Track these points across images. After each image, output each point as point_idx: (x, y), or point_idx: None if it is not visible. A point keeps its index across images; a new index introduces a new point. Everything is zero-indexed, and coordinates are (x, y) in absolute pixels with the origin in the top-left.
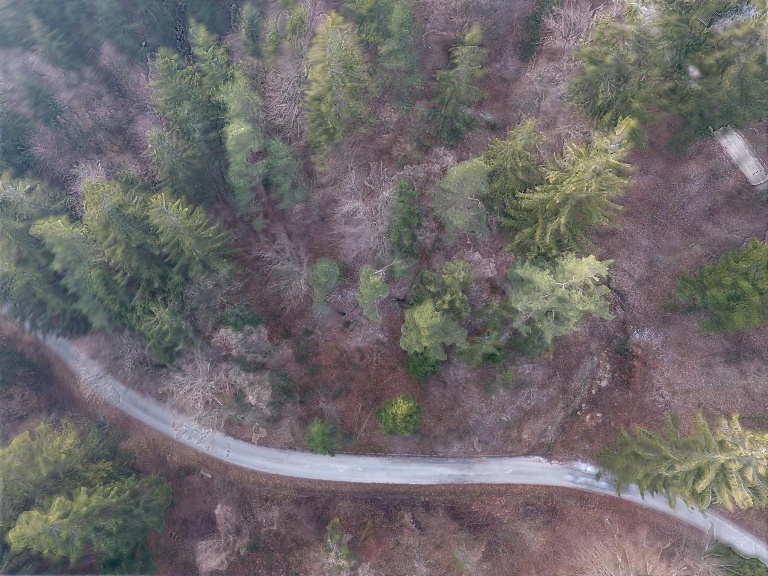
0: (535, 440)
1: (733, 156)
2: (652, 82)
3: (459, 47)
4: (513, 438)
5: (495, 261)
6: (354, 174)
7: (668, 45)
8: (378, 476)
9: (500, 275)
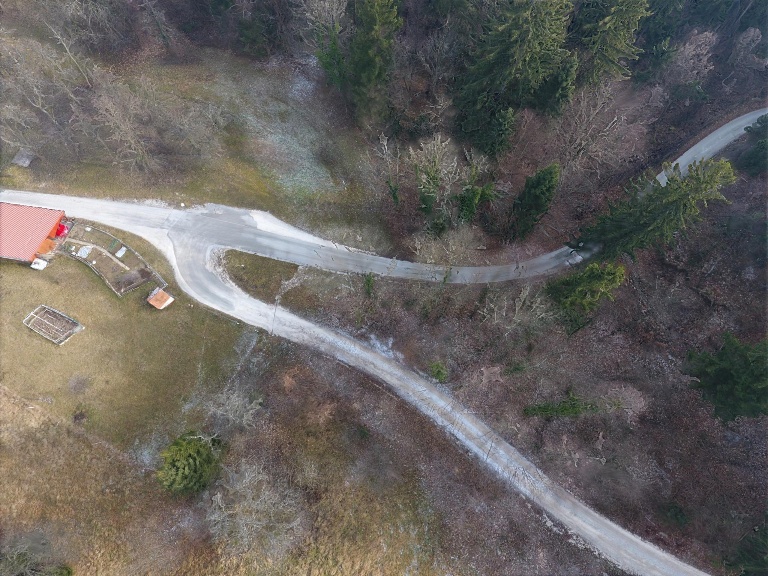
0: None
1: None
2: None
3: None
4: None
5: None
6: None
7: None
8: (684, 160)
9: None
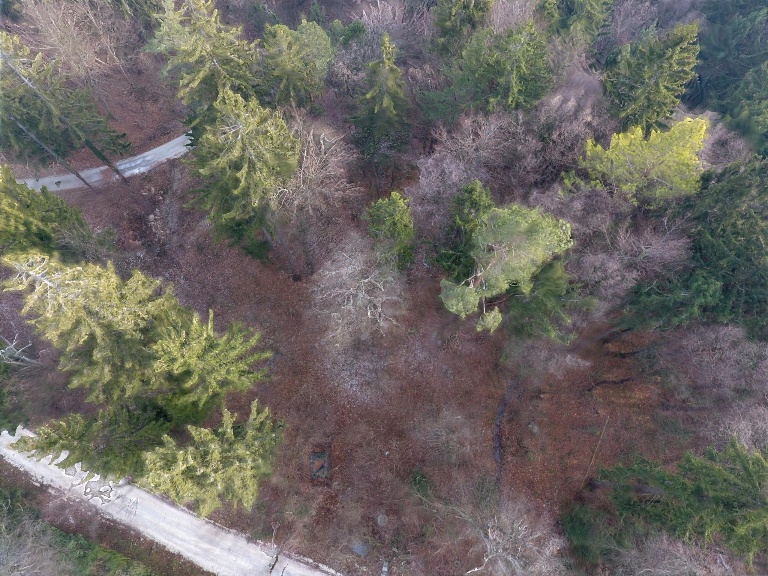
0: None
1: None
2: None
3: None
4: None
5: None
6: (400, 17)
7: None
8: None
9: None
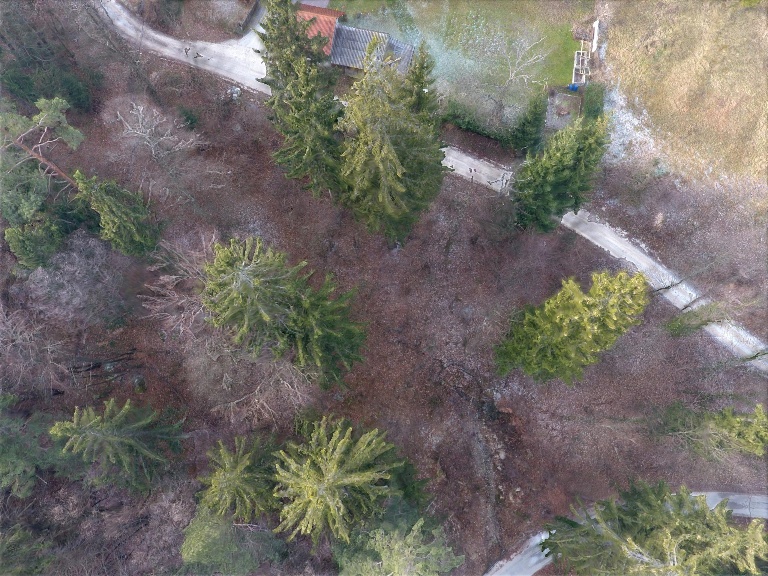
0: (484, 550)
1: (462, 172)
2: (324, 303)
3: (74, 436)
4: (465, 570)
5: (313, 564)
6: None
7: (324, 172)
8: None
9: (330, 561)
